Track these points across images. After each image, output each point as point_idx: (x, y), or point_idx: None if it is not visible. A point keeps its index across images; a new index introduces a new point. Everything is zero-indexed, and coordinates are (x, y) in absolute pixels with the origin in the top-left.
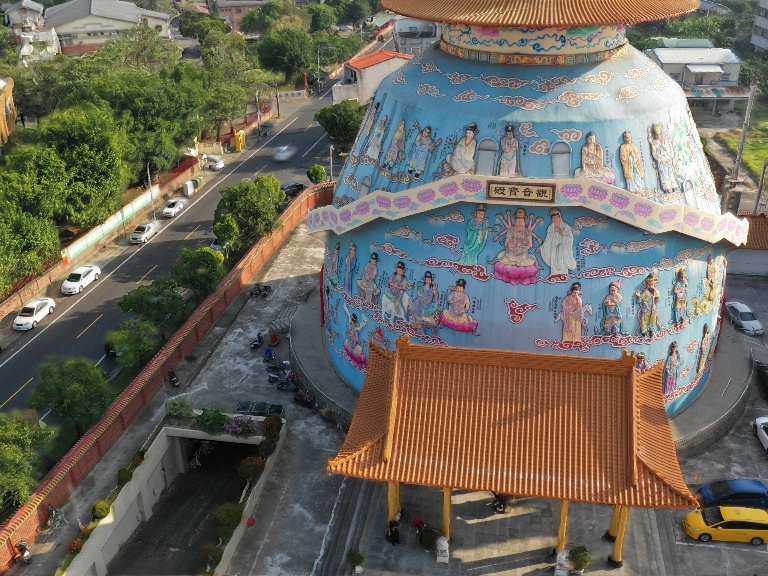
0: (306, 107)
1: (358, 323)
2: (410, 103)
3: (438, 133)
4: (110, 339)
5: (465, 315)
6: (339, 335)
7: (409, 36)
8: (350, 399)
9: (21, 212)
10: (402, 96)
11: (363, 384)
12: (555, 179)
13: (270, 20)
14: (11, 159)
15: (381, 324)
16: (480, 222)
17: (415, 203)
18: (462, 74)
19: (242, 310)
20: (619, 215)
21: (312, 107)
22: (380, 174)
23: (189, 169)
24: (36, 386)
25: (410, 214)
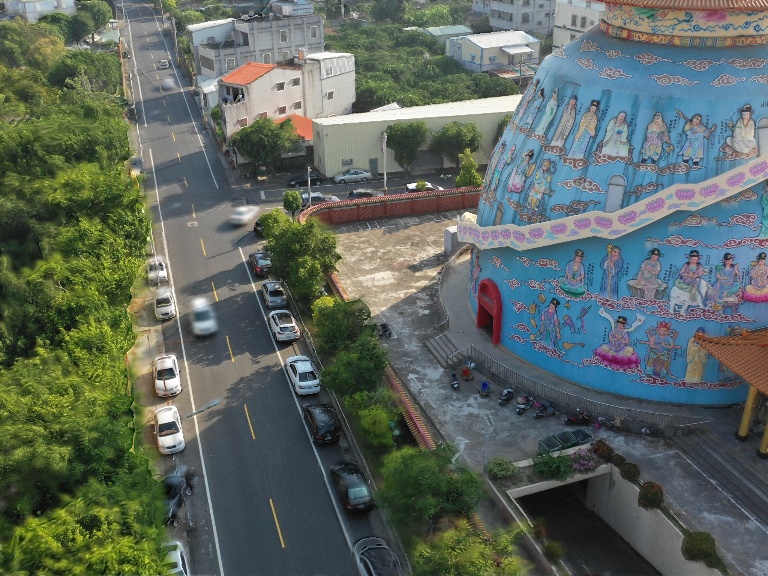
0: (143, 137)
1: (629, 324)
2: (662, 95)
3: (711, 119)
4: (372, 420)
5: (767, 286)
6: (584, 344)
7: (212, 47)
8: (620, 403)
9: (107, 308)
10: (641, 90)
11: (628, 385)
12: None
13: (11, 46)
14: (50, 245)
15: (667, 318)
16: None
17: (724, 189)
18: (701, 61)
19: (386, 356)
20: None
21: (151, 136)
22: (639, 170)
23: None
24: (286, 506)
25: (717, 201)
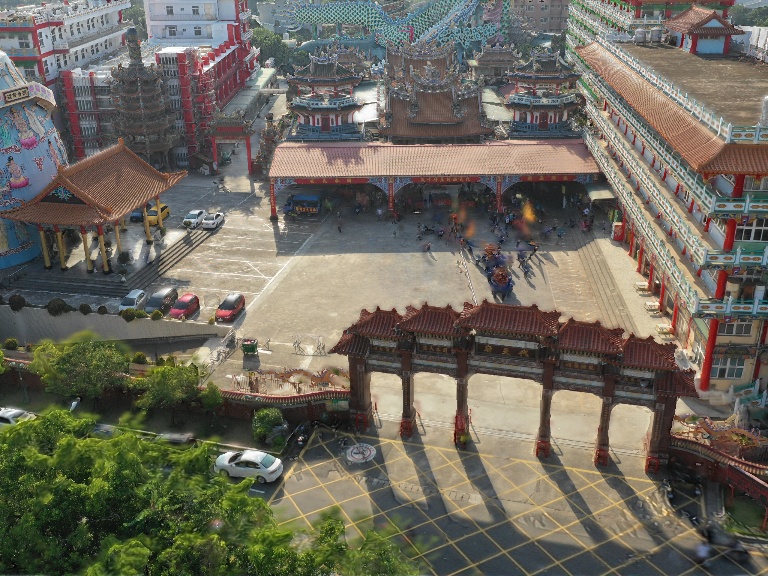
0: None
1: None
2: None
3: None
4: None
5: (22, 176)
6: None
7: None
8: None
9: None
10: None
11: None
12: (25, 84)
13: None
14: None
15: None
16: (0, 121)
17: None
18: None
19: None
20: (46, 98)
21: None
22: None
23: None
24: None
25: None
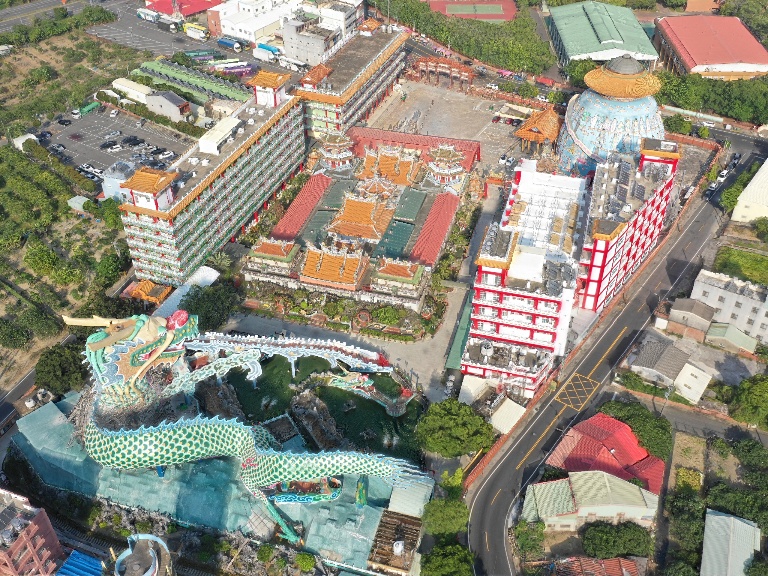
0: None
1: None
2: None
3: None
4: None
5: None
6: None
7: None
8: None
9: None
10: None
11: None
12: None
13: None
14: None
15: None
16: None
17: None
18: None
19: None
20: None
21: None
22: None
23: (750, 127)
24: None
25: None
